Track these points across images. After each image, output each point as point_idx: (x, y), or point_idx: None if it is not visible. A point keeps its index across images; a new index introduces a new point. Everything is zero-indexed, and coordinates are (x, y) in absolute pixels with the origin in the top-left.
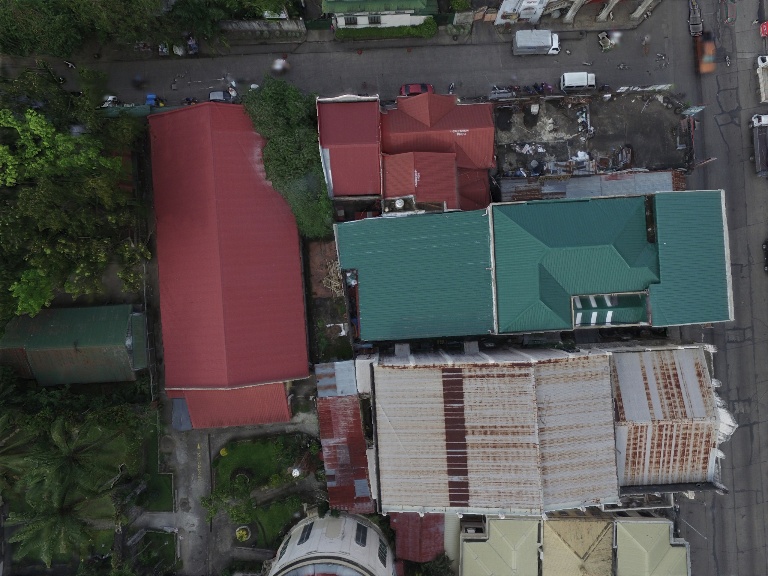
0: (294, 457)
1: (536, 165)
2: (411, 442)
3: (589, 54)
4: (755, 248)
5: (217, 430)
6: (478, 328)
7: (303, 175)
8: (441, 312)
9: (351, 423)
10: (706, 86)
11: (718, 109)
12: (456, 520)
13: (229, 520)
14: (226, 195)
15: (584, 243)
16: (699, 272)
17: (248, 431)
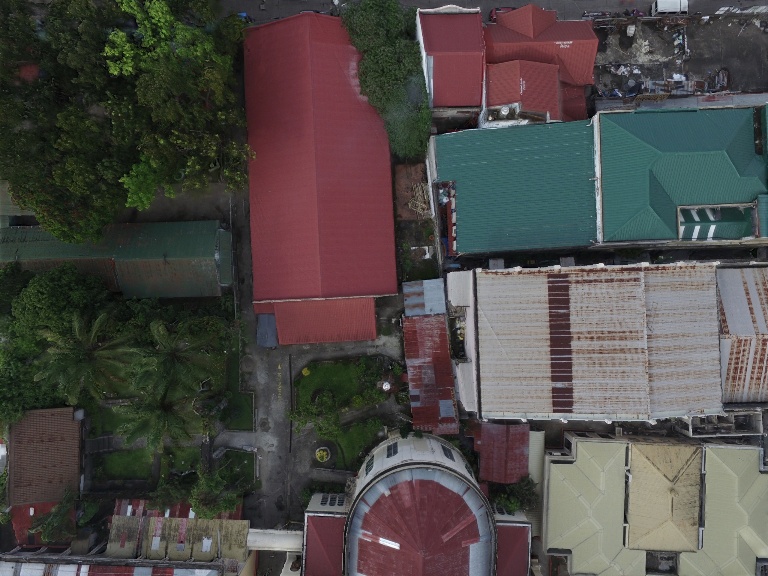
0: (380, 375)
1: (633, 84)
2: (514, 348)
3: None
4: None
5: (298, 351)
6: (580, 239)
7: (402, 86)
8: (541, 223)
9: (437, 343)
10: None
11: None
12: (541, 443)
13: (308, 441)
14: (323, 106)
15: (696, 149)
16: None
17: (329, 352)
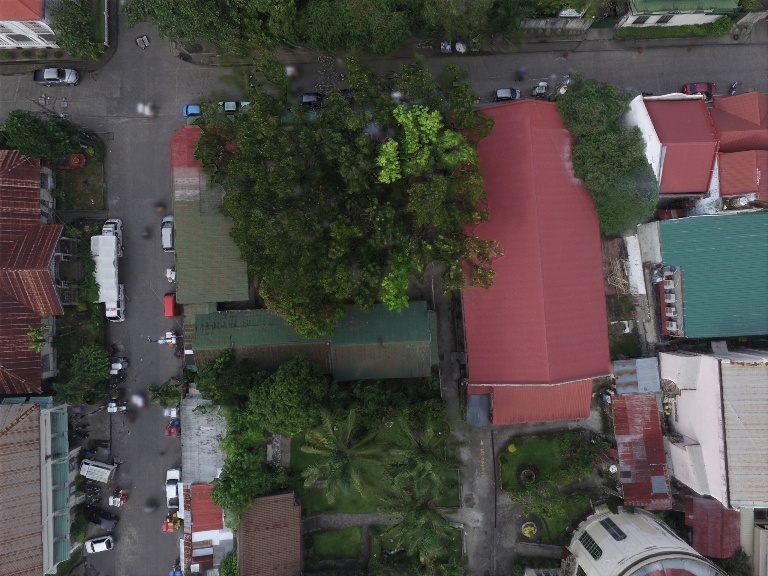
0: (593, 453)
1: None
2: (763, 438)
3: None
4: None
5: (500, 426)
6: None
7: (627, 173)
8: None
9: (648, 420)
10: None
11: None
12: (752, 516)
13: (513, 516)
14: (544, 192)
15: None
16: None
17: (531, 427)
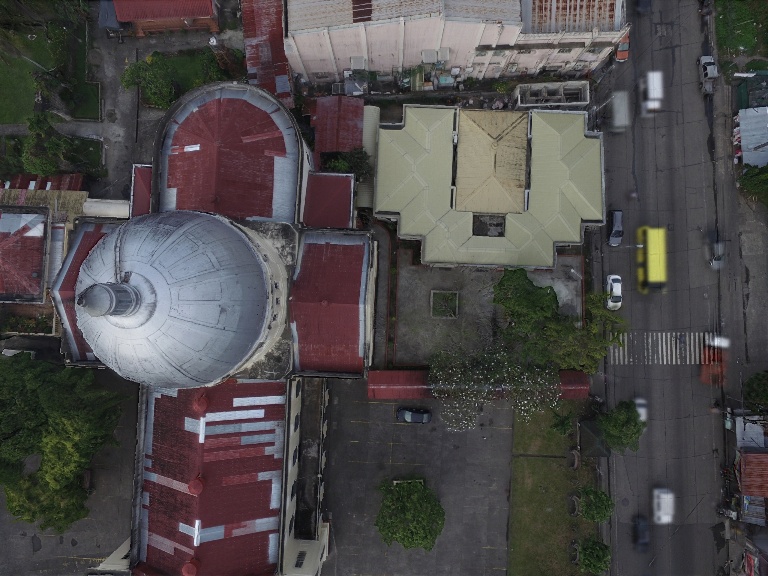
0: None
1: None
2: None
3: None
4: None
5: (145, 45)
6: None
7: None
8: None
9: (273, 20)
10: None
11: None
12: (375, 118)
13: (154, 132)
14: None
15: None
16: None
17: (176, 47)
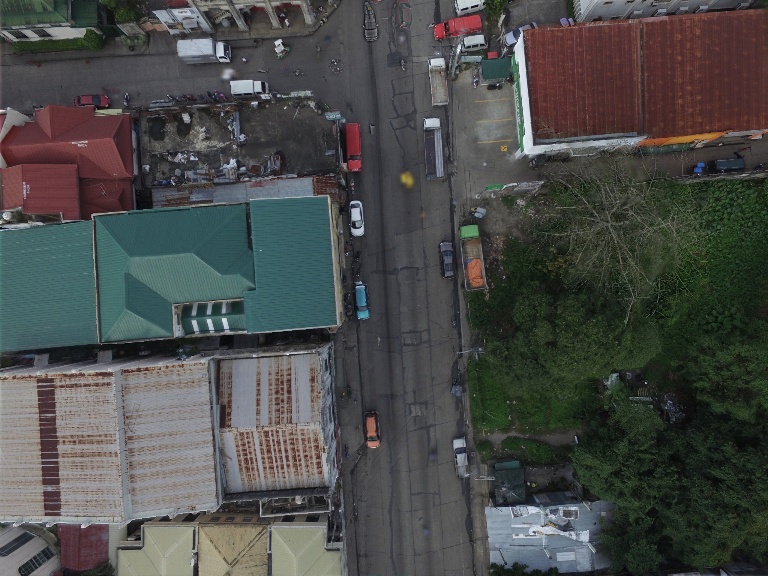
0: None
1: (179, 174)
2: (11, 452)
3: (265, 61)
4: (431, 251)
5: None
6: (92, 338)
7: None
8: (60, 322)
9: None
10: (381, 90)
11: (393, 113)
12: None
13: None
14: None
15: (166, 252)
16: (301, 278)
17: None
